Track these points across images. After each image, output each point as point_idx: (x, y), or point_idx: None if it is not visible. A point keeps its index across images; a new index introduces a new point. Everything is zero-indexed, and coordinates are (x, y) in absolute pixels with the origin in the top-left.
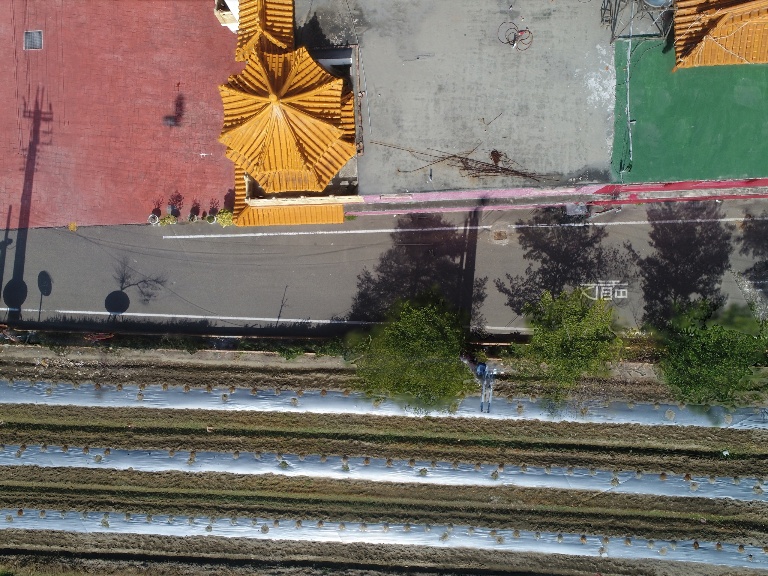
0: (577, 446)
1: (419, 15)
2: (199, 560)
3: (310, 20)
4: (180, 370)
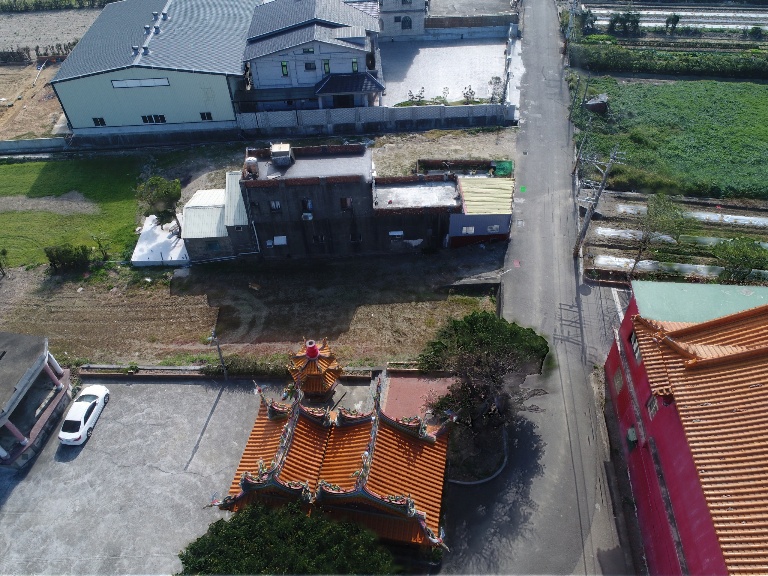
0: None
1: None
2: None
3: None
4: None
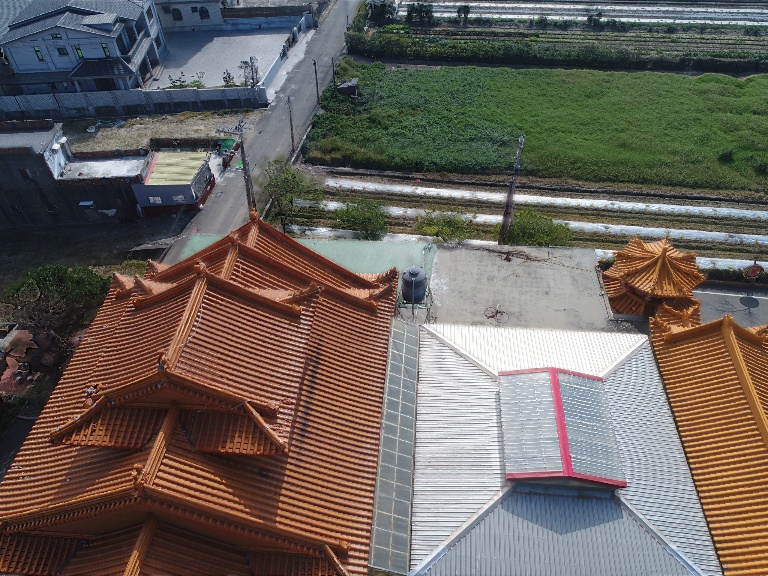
0: None
1: None
2: (650, 195)
3: None
4: None
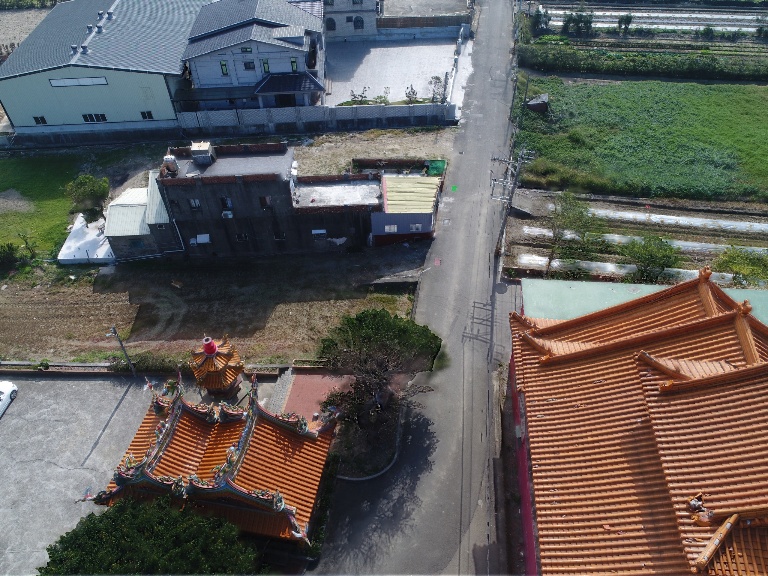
0: (677, 260)
1: None
2: None
3: None
4: None
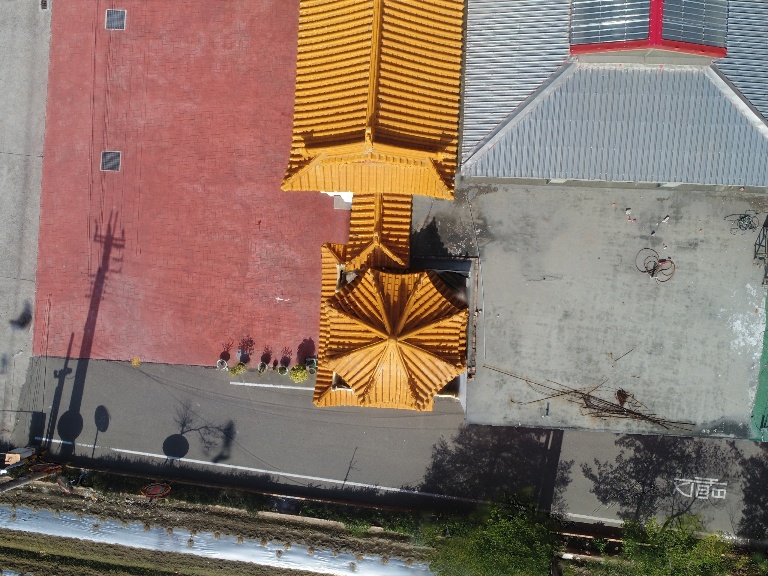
0: None
1: (549, 231)
2: None
3: (428, 225)
4: (234, 519)
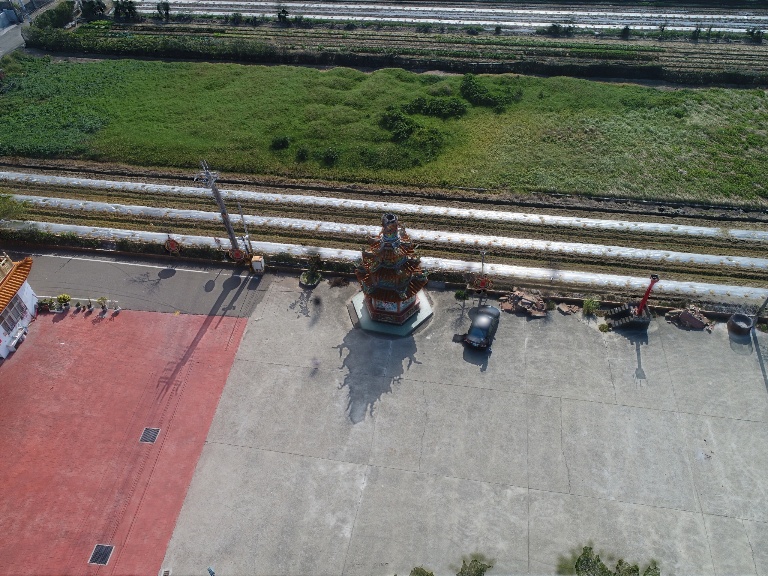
0: None
1: None
2: (186, 179)
3: None
4: None
